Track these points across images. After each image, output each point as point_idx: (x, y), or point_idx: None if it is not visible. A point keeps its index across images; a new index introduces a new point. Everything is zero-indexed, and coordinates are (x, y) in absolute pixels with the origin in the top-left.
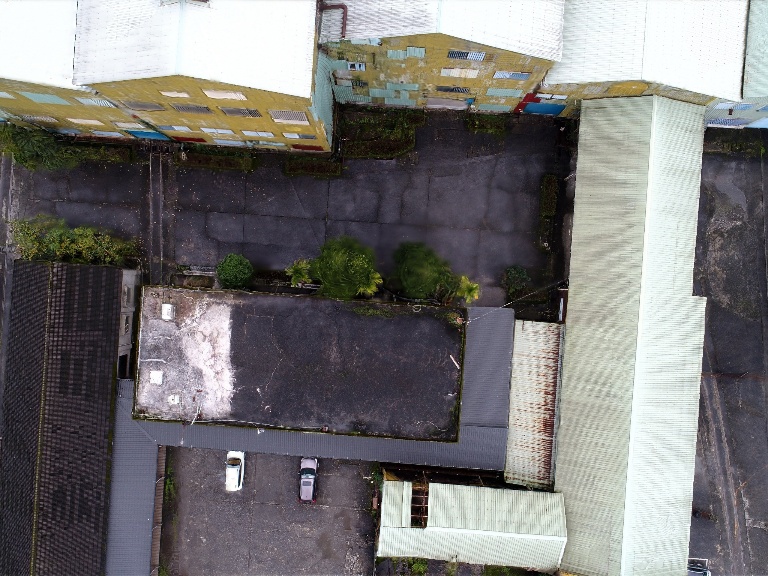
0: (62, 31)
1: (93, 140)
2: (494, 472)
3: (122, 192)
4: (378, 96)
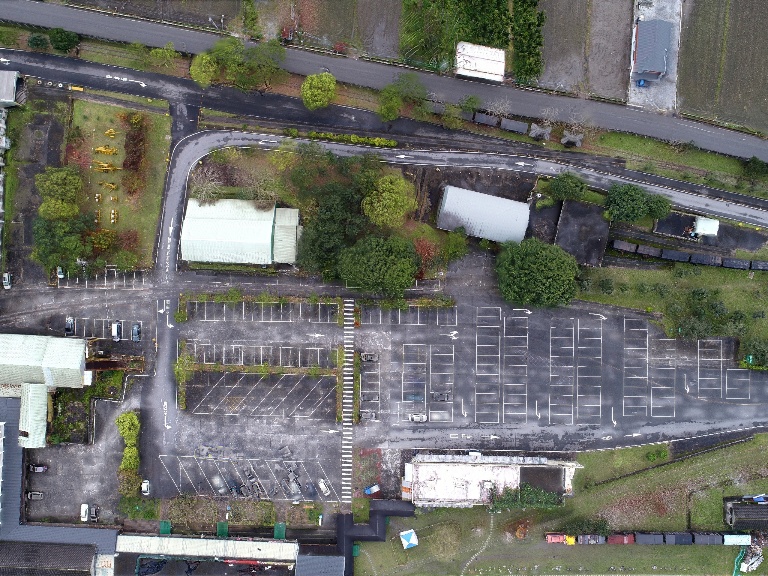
0: None
1: None
2: None
3: None
4: None
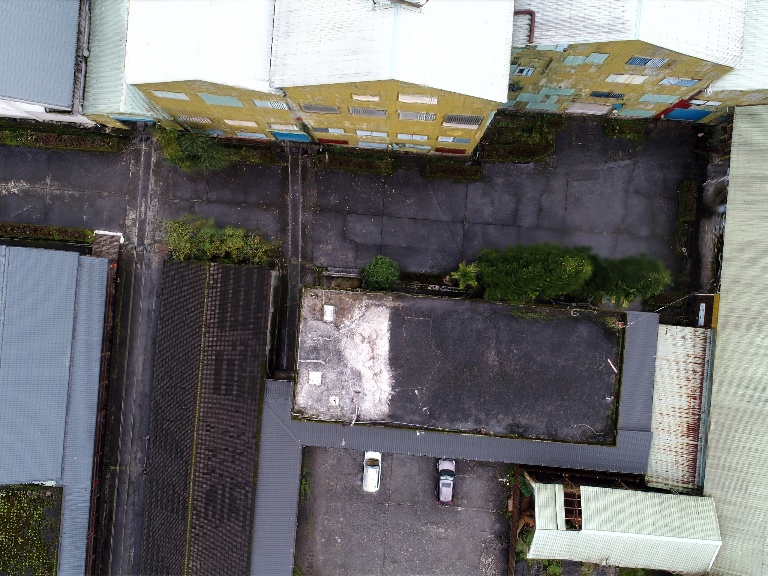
0: (255, 34)
1: (233, 141)
2: (636, 476)
3: (261, 193)
4: (524, 100)
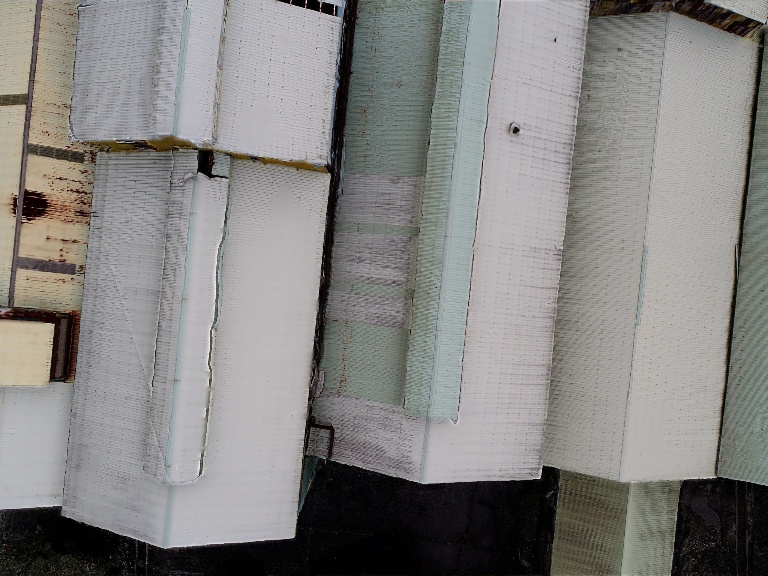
0: (53, 453)
1: None
2: None
3: None
4: None
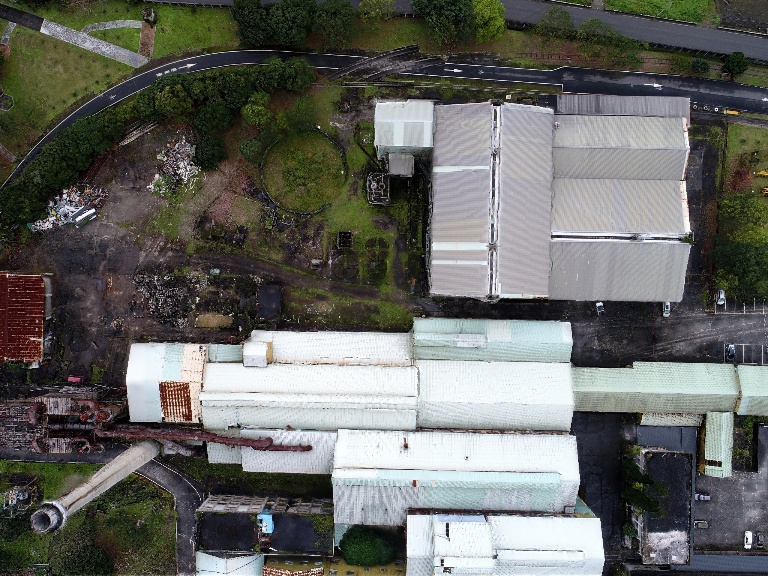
0: None
1: None
2: (697, 431)
3: None
4: None
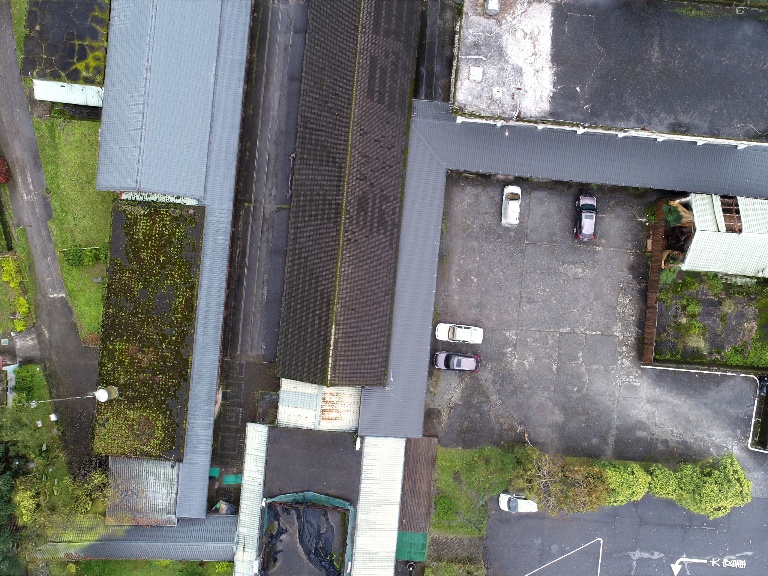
0: None
1: None
2: None
3: None
4: None
